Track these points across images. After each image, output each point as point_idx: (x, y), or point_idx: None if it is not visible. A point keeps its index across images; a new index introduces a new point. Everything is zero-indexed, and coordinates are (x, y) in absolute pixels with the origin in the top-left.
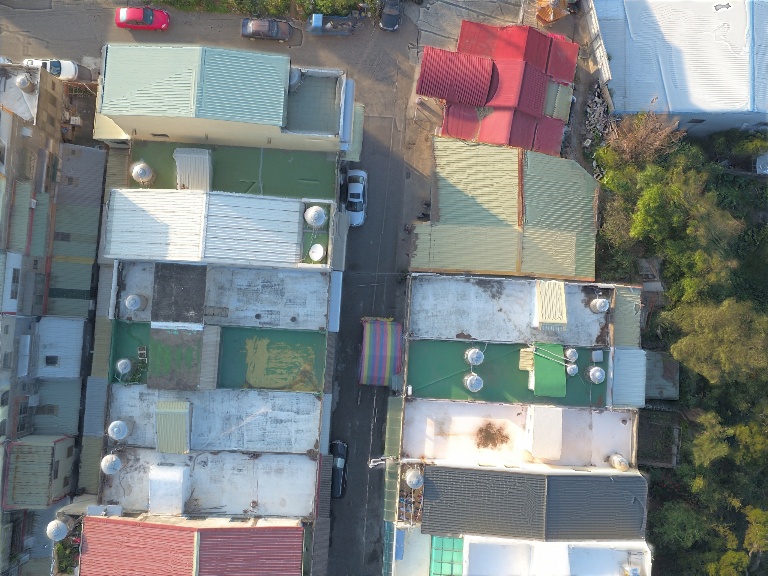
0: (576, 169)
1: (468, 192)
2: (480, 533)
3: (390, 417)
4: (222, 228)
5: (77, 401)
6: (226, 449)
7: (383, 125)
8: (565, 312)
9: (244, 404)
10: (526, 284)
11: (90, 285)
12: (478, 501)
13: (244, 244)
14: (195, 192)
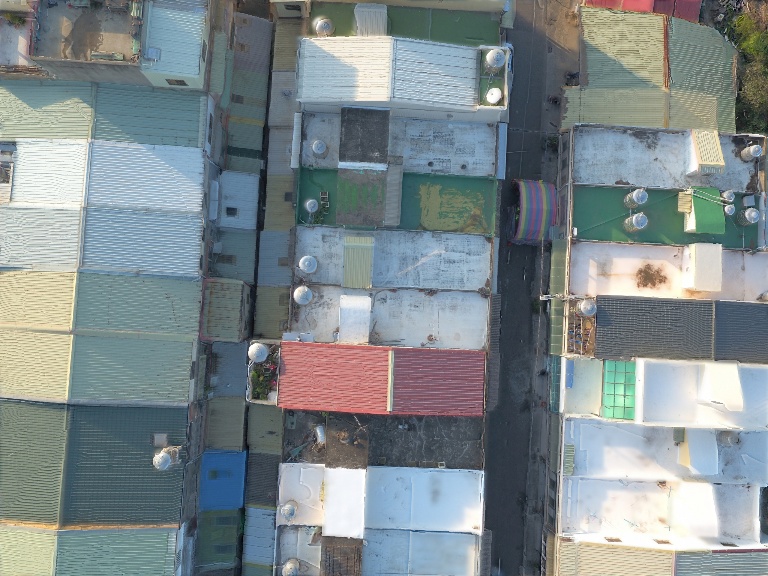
0: (716, 36)
1: (615, 57)
2: (650, 357)
3: (555, 258)
4: (408, 71)
5: (253, 253)
6: (404, 286)
7: (526, 3)
8: (722, 156)
9: (419, 245)
10: (680, 135)
11: (261, 146)
12: (640, 335)
13: (428, 87)
14: (383, 38)
